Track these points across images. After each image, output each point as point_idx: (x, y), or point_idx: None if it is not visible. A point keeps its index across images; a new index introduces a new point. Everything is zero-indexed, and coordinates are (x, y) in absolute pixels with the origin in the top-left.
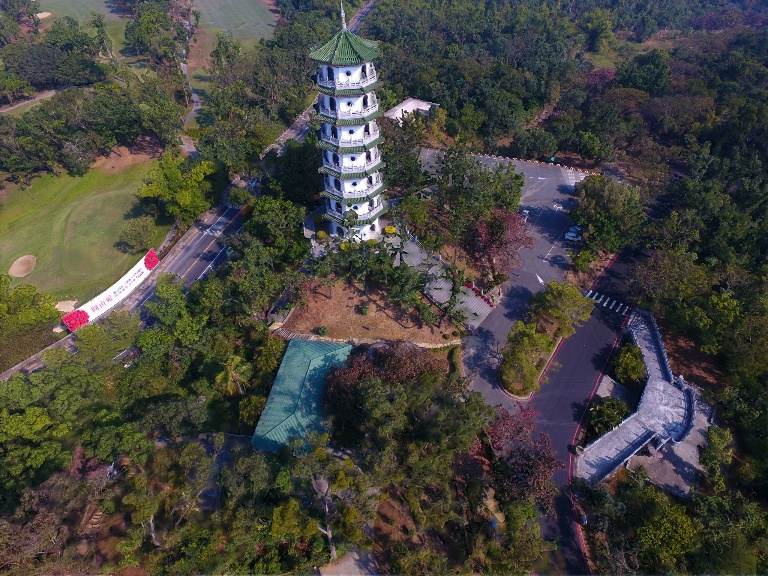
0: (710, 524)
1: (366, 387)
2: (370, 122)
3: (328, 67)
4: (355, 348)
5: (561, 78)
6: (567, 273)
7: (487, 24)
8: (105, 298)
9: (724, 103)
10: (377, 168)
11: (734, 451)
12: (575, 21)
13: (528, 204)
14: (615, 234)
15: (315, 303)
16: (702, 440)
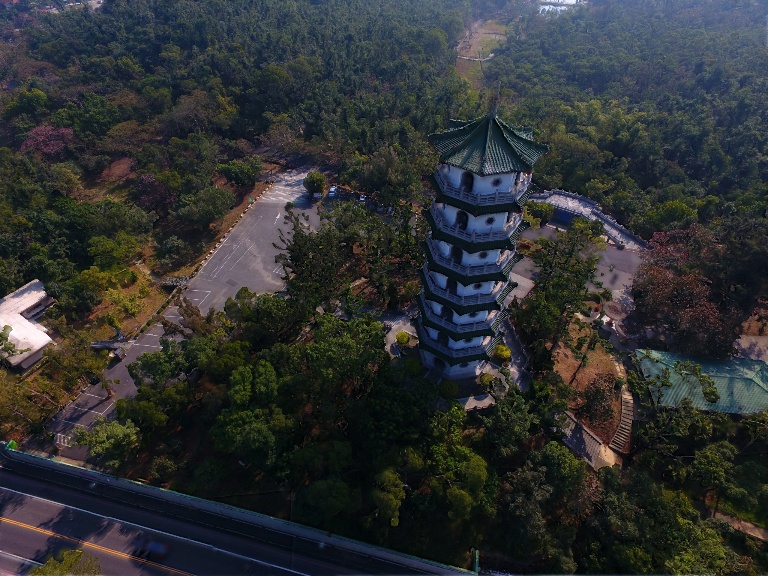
0: None
1: None
2: None
3: None
4: None
5: None
6: None
7: None
8: None
9: (189, 91)
10: None
11: None
12: None
13: None
14: None
15: None
16: None
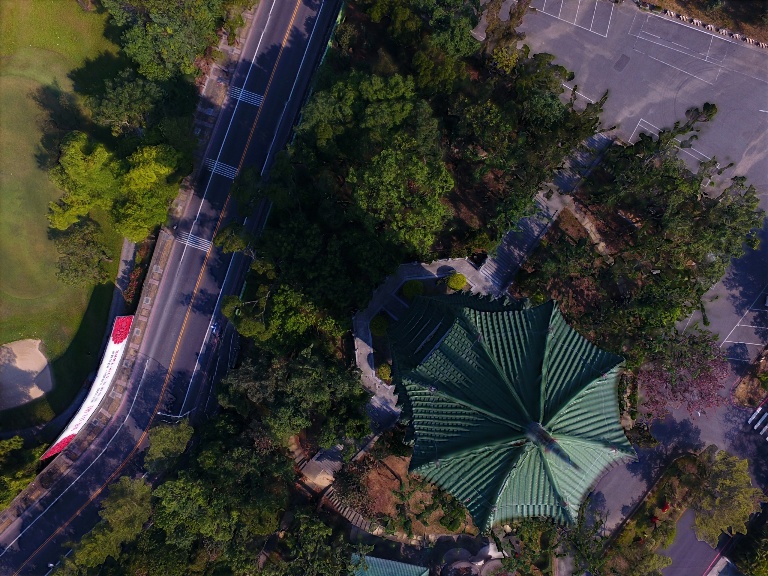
0: None
1: None
2: None
3: None
4: (431, 548)
5: None
6: (740, 383)
7: None
8: (83, 413)
9: None
10: None
11: None
12: None
13: None
14: None
15: (378, 475)
16: None
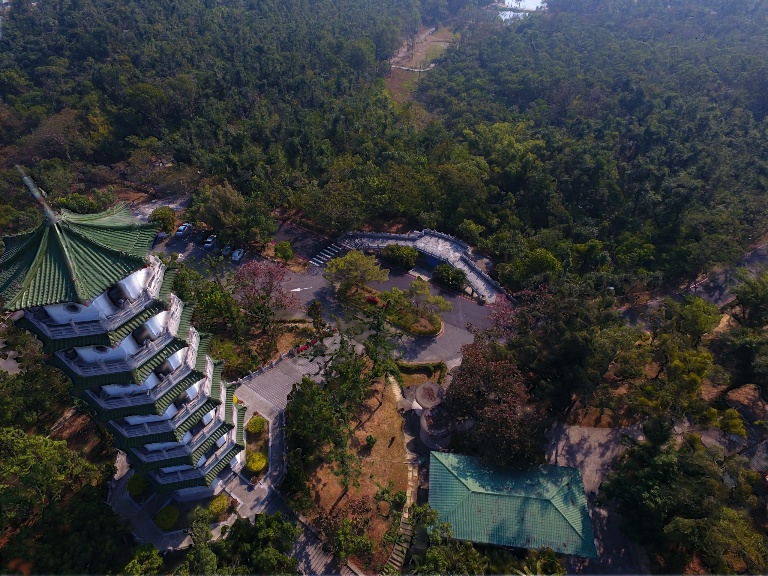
0: None
1: (613, 345)
2: None
3: None
4: (420, 457)
5: None
6: (289, 270)
7: None
8: None
9: None
10: None
11: None
12: None
13: None
14: None
15: None
16: None
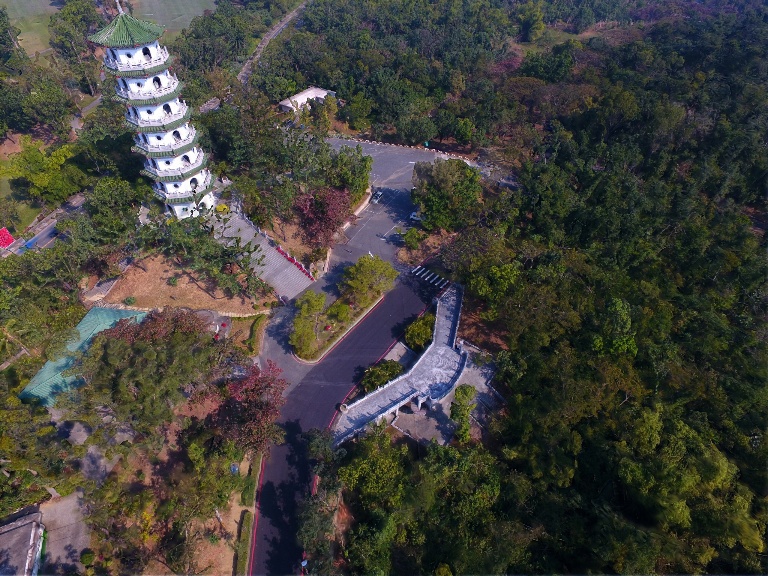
0: (430, 469)
1: None
2: (169, 103)
3: (111, 50)
4: None
5: (474, 68)
6: (399, 250)
7: (416, 15)
8: None
9: None
10: (188, 147)
11: (506, 410)
12: (508, 12)
13: (388, 186)
14: (446, 213)
15: (134, 276)
16: (473, 400)
